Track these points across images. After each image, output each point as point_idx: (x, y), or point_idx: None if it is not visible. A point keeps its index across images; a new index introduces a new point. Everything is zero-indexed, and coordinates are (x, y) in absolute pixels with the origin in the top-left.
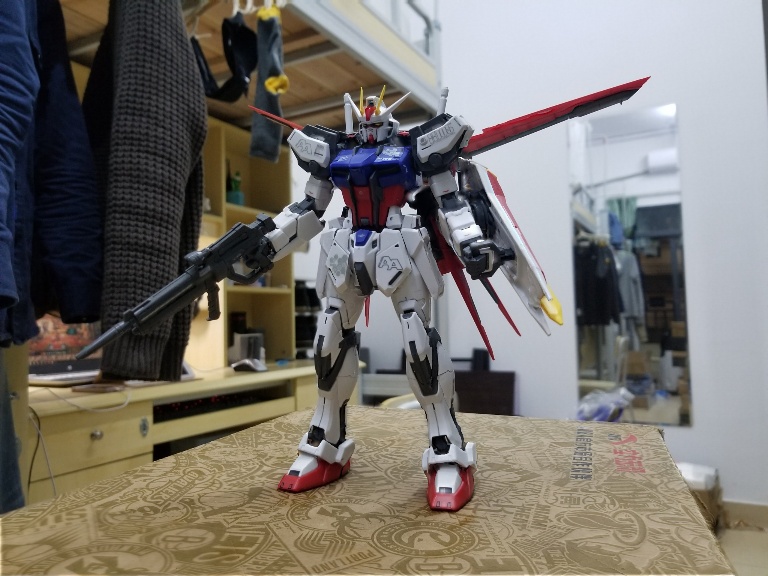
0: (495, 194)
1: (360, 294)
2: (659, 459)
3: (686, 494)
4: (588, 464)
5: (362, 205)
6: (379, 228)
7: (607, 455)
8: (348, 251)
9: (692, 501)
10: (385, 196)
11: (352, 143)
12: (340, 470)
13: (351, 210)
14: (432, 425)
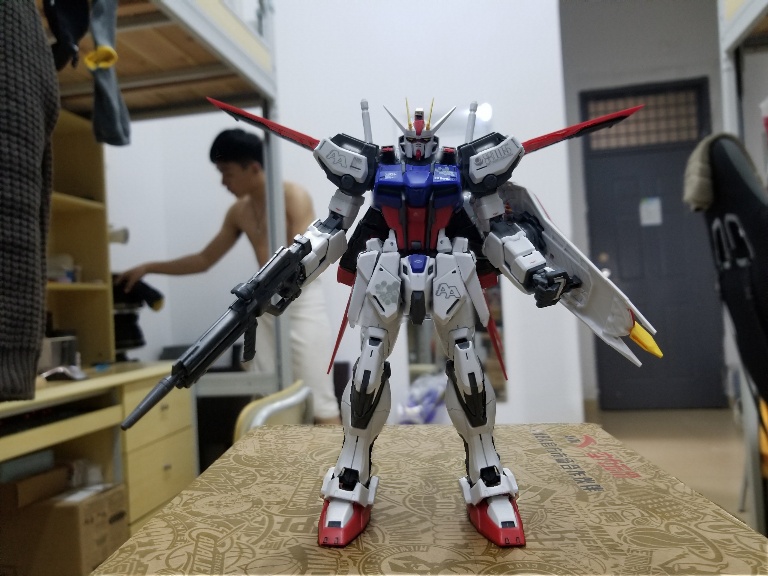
0: (547, 218)
1: (404, 323)
2: (638, 461)
3: (702, 497)
4: (583, 473)
5: (414, 227)
6: (429, 252)
7: (588, 460)
8: (399, 277)
9: (715, 505)
10: (437, 218)
11: (389, 157)
12: (369, 512)
13: (394, 231)
14: (479, 456)
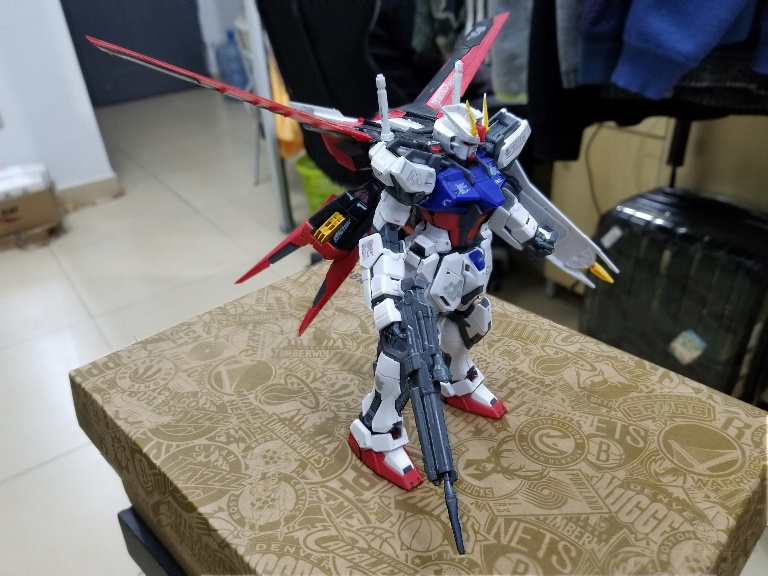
0: None
1: None
2: None
3: (531, 314)
4: None
5: None
6: None
7: None
8: None
9: (543, 318)
10: None
11: None
12: None
13: (448, 231)
14: None
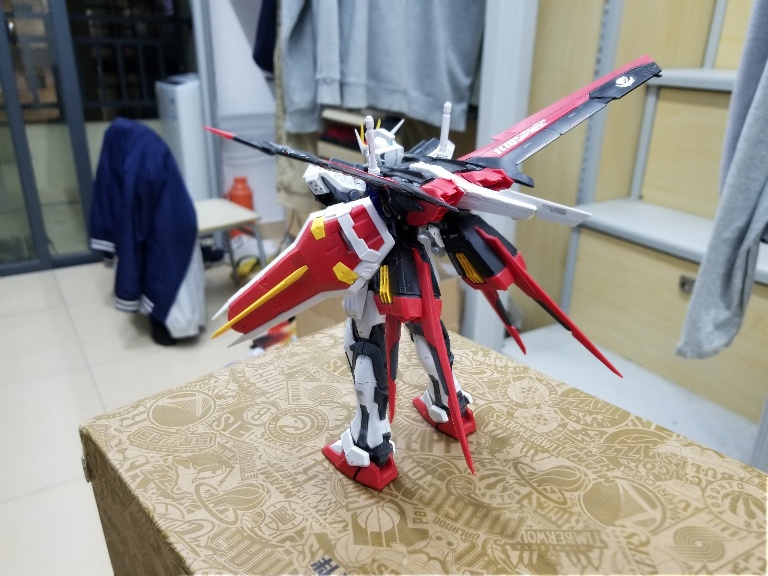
0: None
1: None
2: None
3: None
4: None
5: None
6: None
7: None
8: None
9: (197, 570)
10: None
11: None
12: None
13: None
14: None
